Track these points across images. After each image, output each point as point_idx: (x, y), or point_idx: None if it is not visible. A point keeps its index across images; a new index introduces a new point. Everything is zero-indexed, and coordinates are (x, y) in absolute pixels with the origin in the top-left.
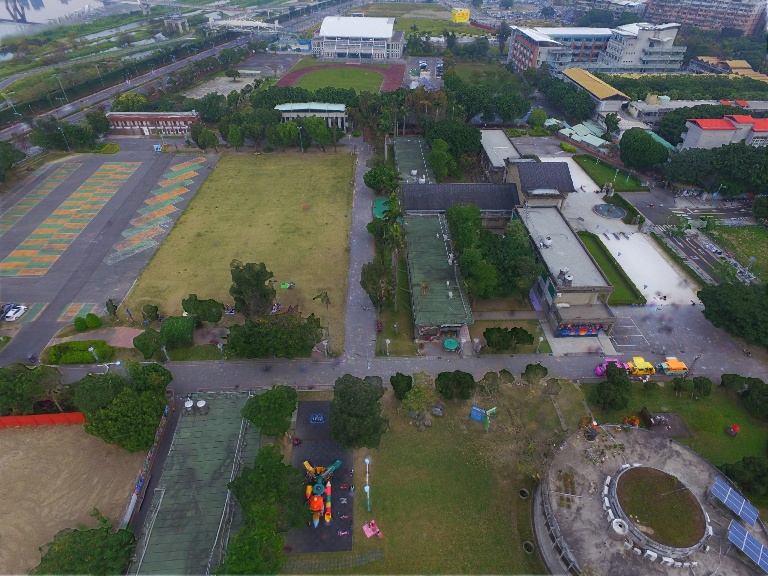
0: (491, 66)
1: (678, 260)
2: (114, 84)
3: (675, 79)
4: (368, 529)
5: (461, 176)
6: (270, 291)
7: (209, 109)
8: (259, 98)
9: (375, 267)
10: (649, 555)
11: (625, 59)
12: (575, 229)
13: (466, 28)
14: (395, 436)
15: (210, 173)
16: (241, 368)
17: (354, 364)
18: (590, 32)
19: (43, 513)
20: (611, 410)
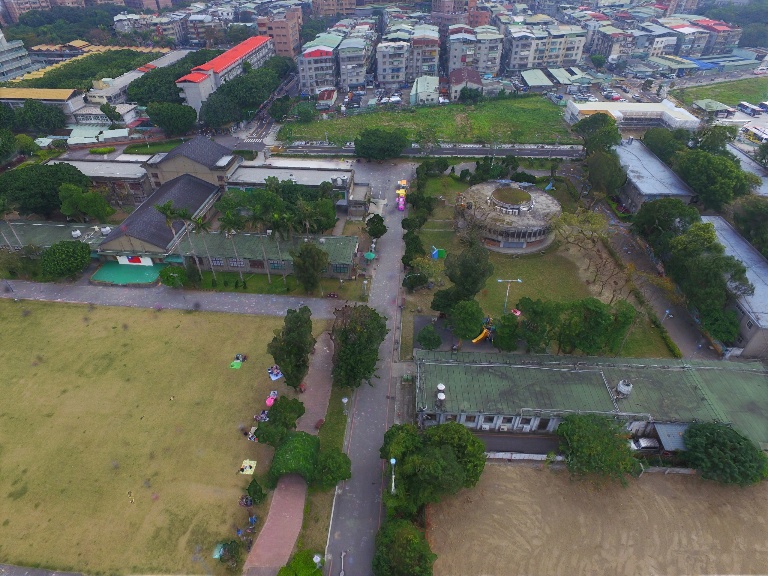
0: None
1: (308, 156)
2: None
3: (73, 66)
4: (518, 313)
5: (112, 209)
6: (310, 327)
7: None
8: None
9: (314, 246)
10: None
11: None
12: None
13: None
14: None
15: None
16: (363, 396)
17: None
18: None
19: (539, 543)
20: None
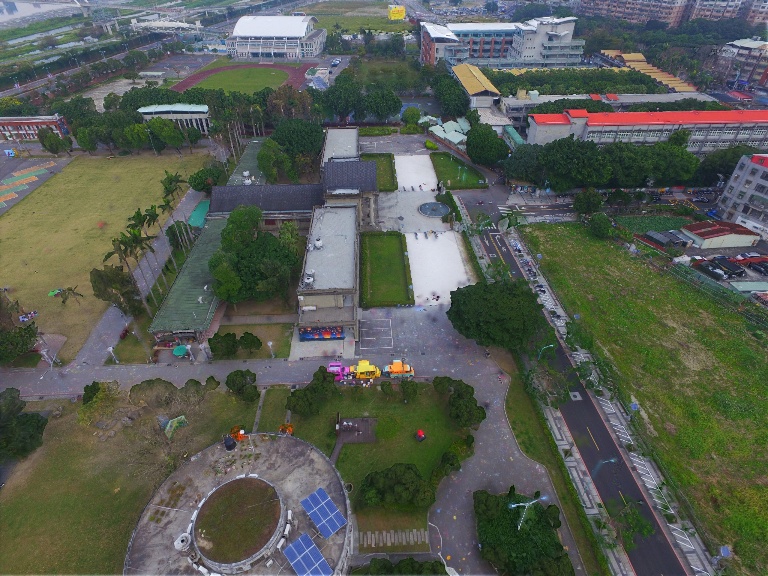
0: (403, 63)
1: (472, 259)
2: (7, 88)
3: (558, 73)
4: None
5: (296, 176)
6: None
7: (74, 112)
8: (124, 100)
9: (100, 273)
10: (200, 571)
11: (526, 54)
12: (388, 229)
13: (401, 25)
14: (71, 448)
15: (50, 178)
16: None
17: (76, 373)
18: (500, 27)
19: None
20: (311, 416)
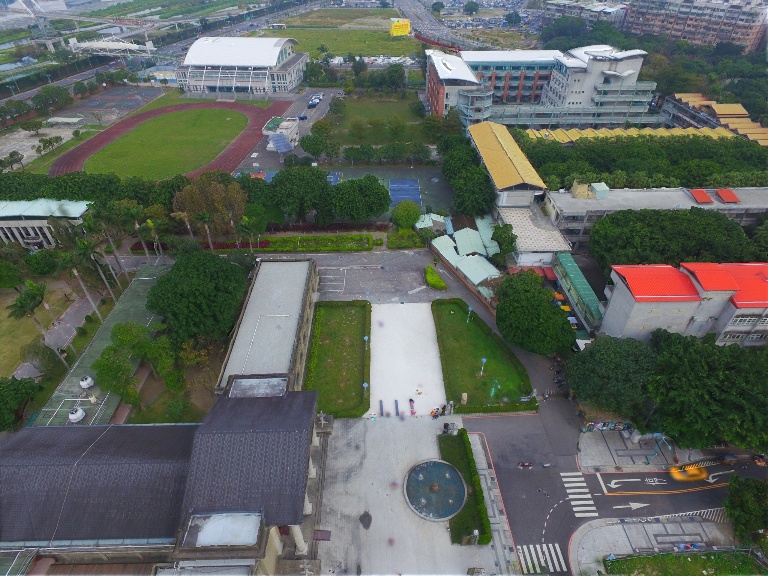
0: (403, 103)
1: None
2: None
3: (629, 143)
4: None
5: (180, 384)
6: None
7: None
8: None
9: None
10: None
11: (570, 100)
12: (336, 565)
13: (405, 43)
14: None
15: None
16: None
17: None
18: (532, 57)
19: None
20: None
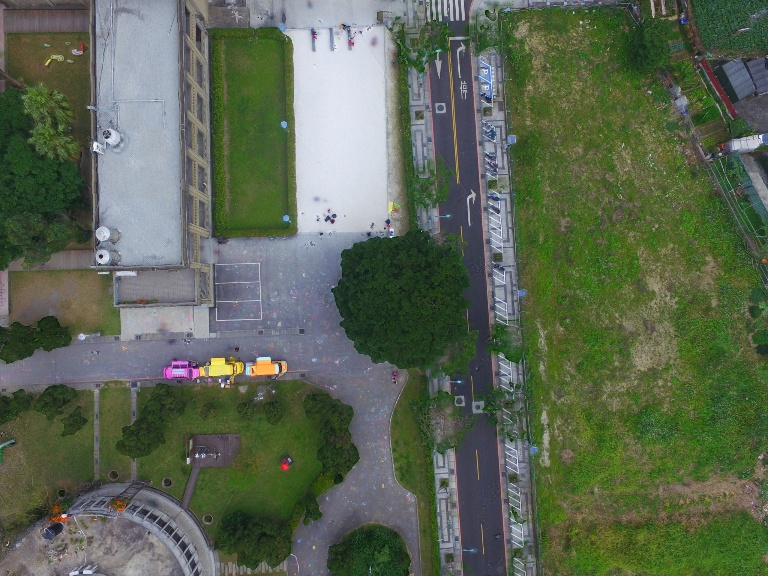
0: None
1: (402, 122)
2: None
3: None
4: None
5: None
6: None
7: None
8: None
9: None
10: None
11: None
12: (263, 13)
13: None
14: None
15: None
16: None
17: None
18: None
19: None
20: None
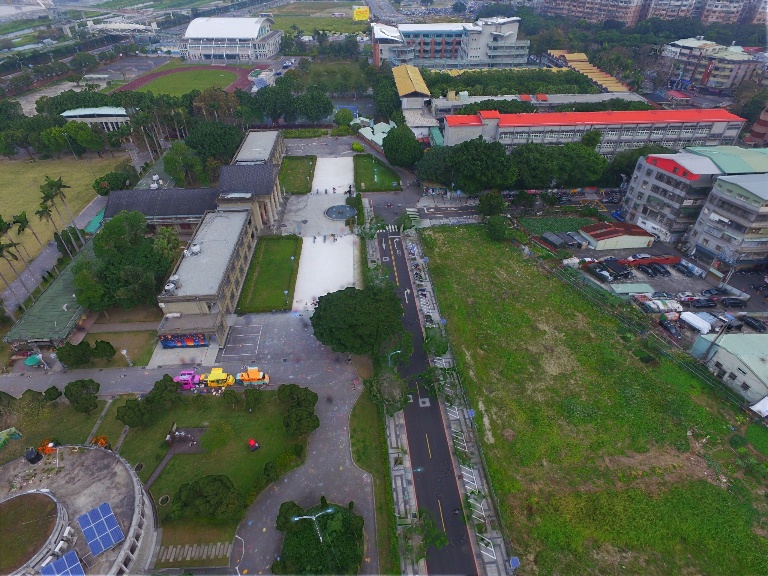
0: (356, 64)
1: (362, 262)
2: None
3: (495, 74)
4: None
5: (207, 180)
6: None
7: None
8: (50, 104)
9: None
10: None
11: (471, 54)
12: (289, 232)
13: None
14: None
15: None
16: None
17: None
18: (451, 28)
19: None
20: (150, 426)
